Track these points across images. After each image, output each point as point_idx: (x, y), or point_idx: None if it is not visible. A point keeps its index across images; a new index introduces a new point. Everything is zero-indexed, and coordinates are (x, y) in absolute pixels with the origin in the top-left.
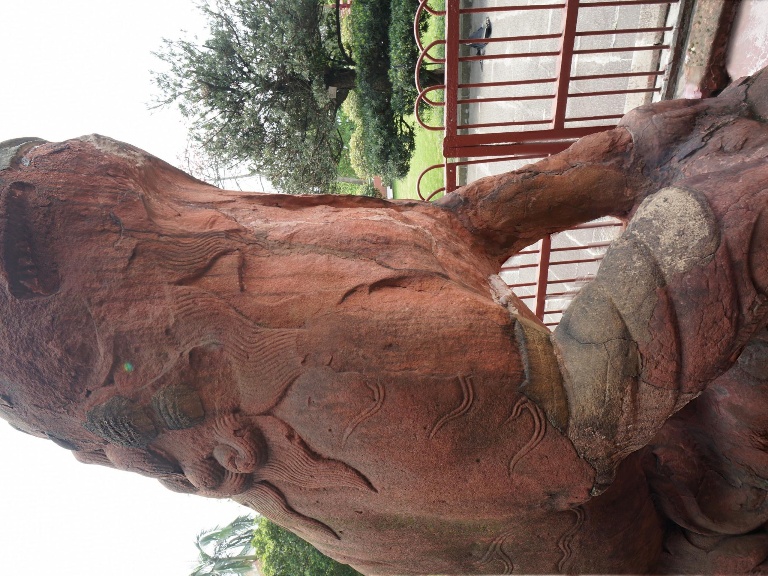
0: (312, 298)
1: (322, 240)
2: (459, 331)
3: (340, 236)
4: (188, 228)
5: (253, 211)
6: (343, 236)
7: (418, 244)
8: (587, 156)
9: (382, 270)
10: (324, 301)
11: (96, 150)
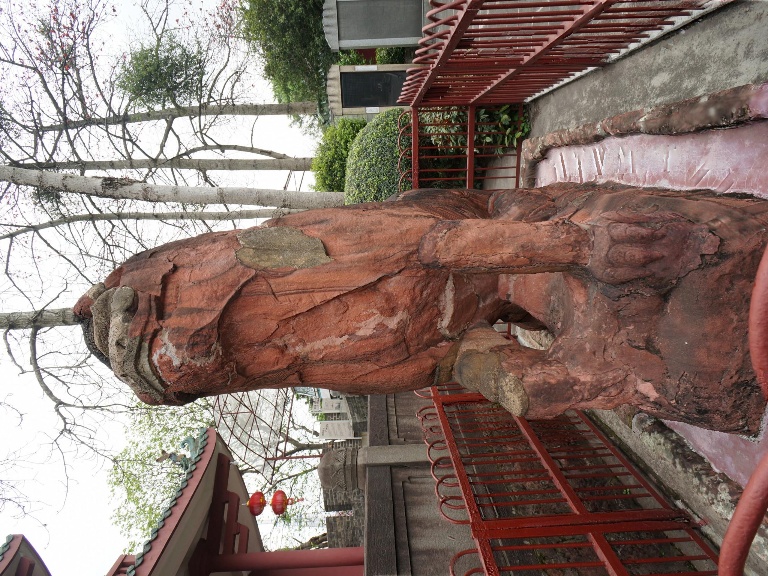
0: (338, 380)
1: (341, 358)
2: (407, 384)
3: (351, 355)
4: (265, 368)
5: (293, 334)
6: (352, 355)
7: (396, 344)
8: (548, 260)
9: (373, 366)
10: (344, 381)
11: (199, 367)
